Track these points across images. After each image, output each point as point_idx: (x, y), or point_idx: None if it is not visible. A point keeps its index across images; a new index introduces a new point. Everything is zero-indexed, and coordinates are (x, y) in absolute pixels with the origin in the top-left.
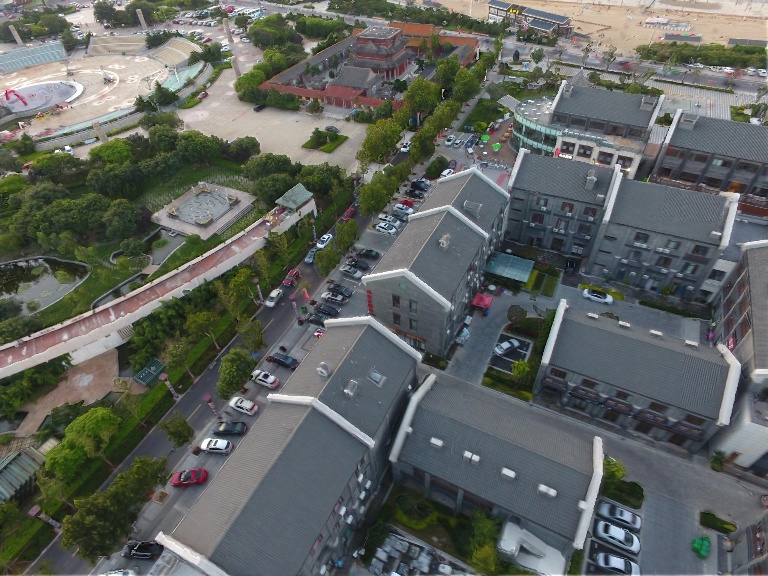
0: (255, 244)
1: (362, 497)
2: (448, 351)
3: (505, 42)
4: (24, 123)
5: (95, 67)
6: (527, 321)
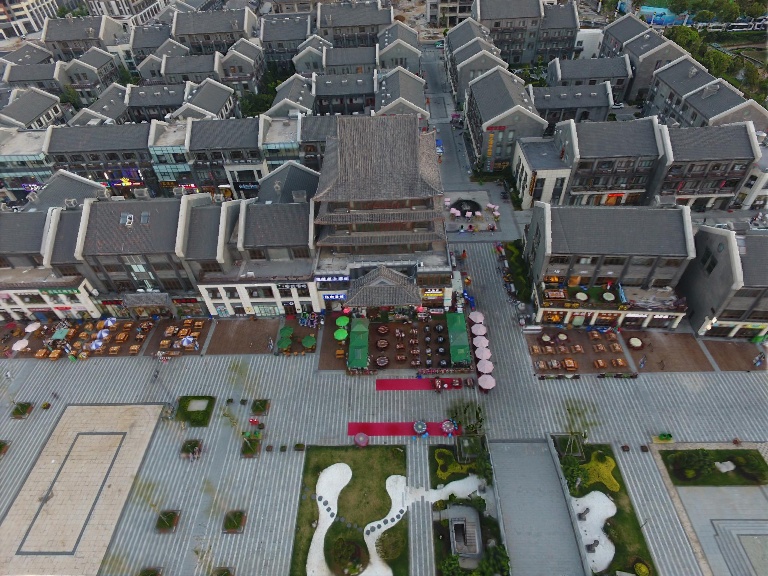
0: None
1: None
2: None
3: None
4: None
5: None
6: None
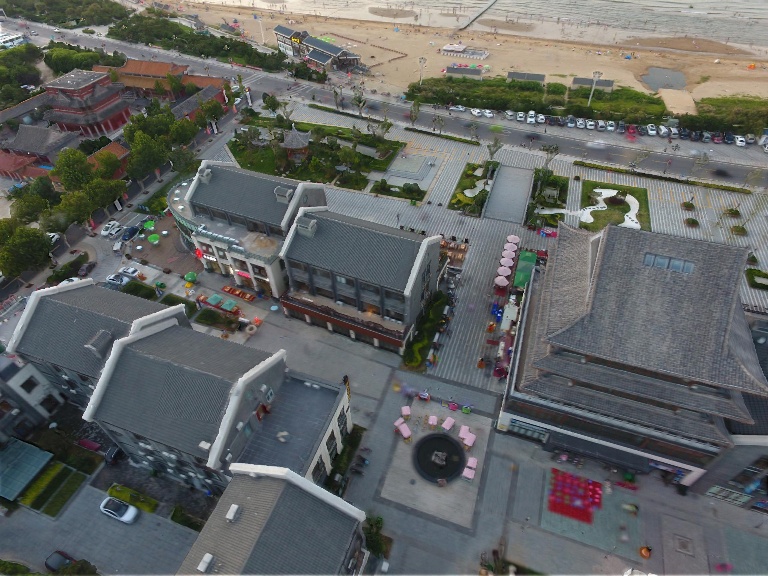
0: None
1: None
2: None
3: (276, 78)
4: None
5: None
6: None
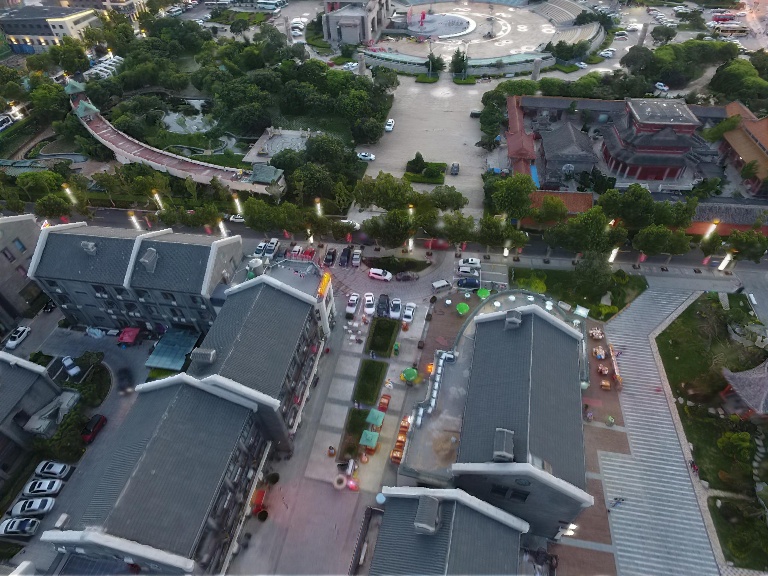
0: (208, 178)
1: None
2: (82, 326)
3: None
4: (396, 38)
5: (513, 21)
6: (105, 380)
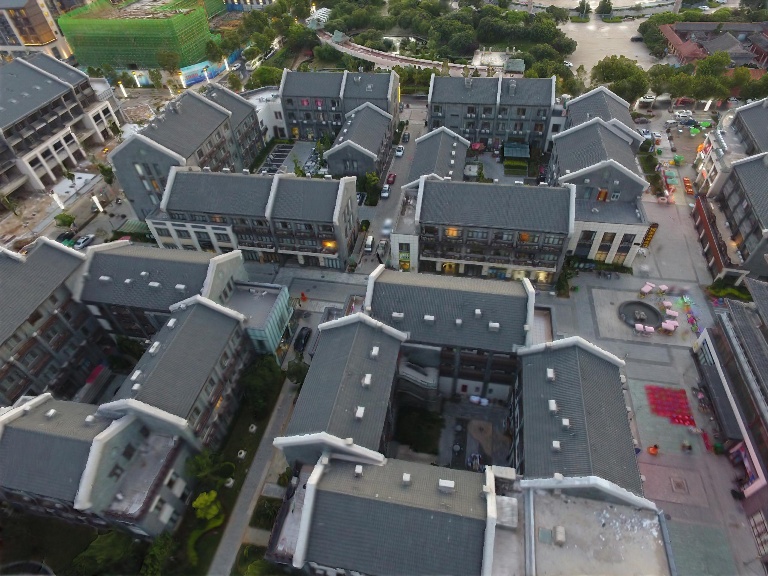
0: None
1: (333, 123)
2: None
3: None
4: None
5: None
6: None
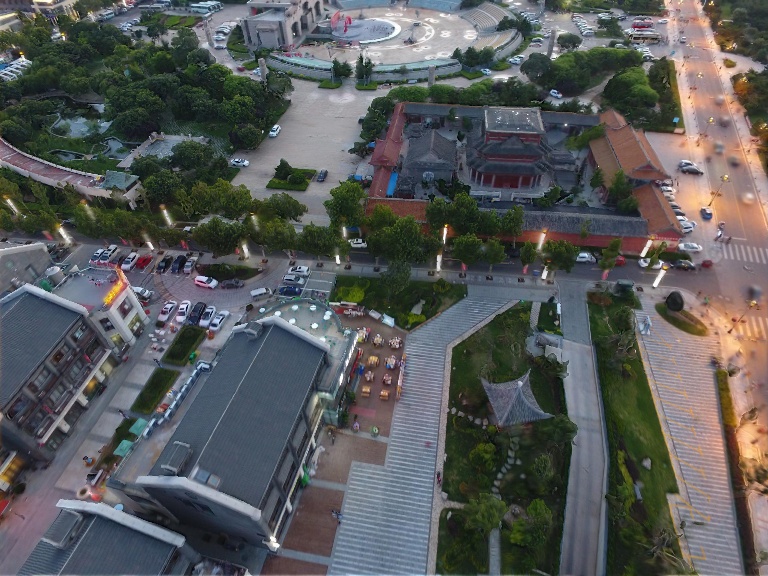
0: (66, 184)
1: None
2: None
3: None
4: (318, 43)
5: (438, 27)
6: None
